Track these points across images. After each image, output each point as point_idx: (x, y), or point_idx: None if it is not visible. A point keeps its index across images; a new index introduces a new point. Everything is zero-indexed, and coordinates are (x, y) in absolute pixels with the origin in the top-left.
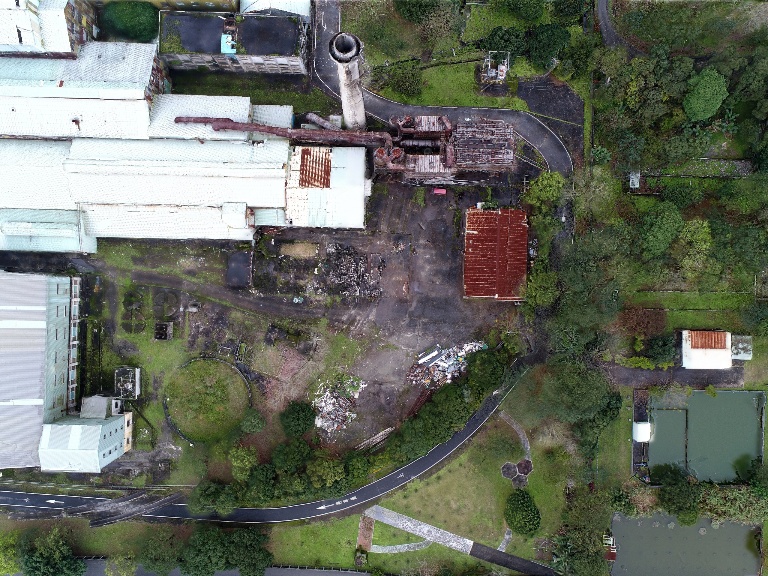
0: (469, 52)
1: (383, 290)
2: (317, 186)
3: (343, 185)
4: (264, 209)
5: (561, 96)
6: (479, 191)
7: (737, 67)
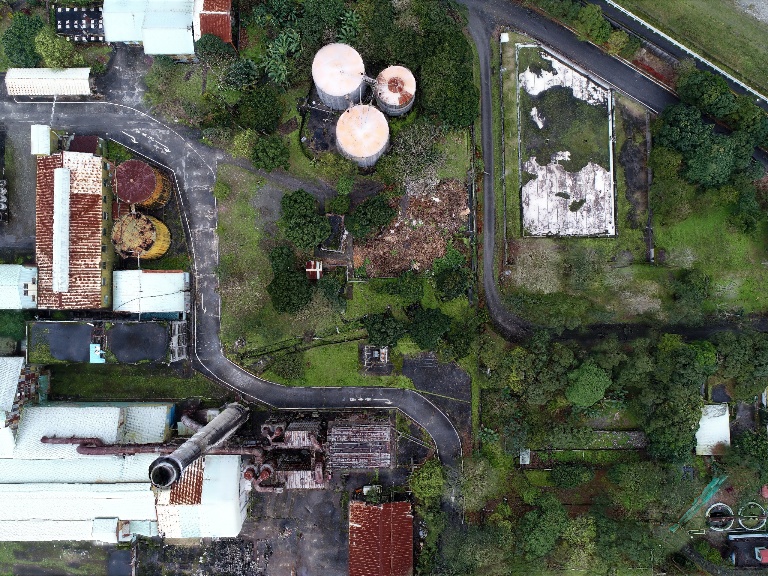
0: (353, 329)
1: None
2: (188, 503)
3: (214, 500)
4: (137, 521)
5: (447, 373)
6: (366, 472)
7: (616, 363)
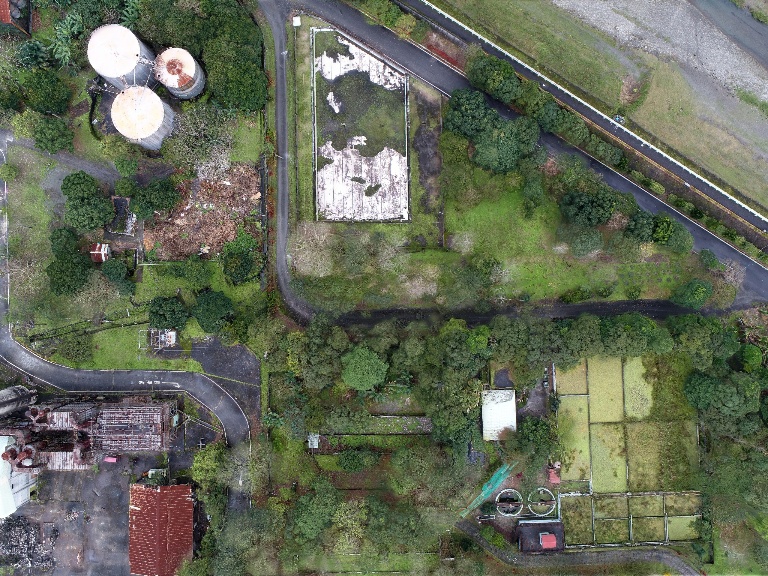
0: (143, 312)
1: (57, 560)
2: None
3: None
4: None
5: (236, 356)
6: (155, 455)
7: (386, 347)
